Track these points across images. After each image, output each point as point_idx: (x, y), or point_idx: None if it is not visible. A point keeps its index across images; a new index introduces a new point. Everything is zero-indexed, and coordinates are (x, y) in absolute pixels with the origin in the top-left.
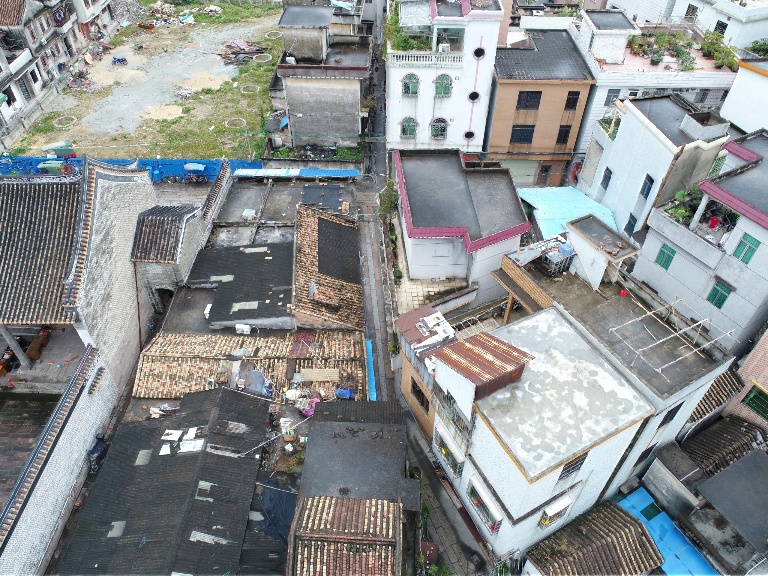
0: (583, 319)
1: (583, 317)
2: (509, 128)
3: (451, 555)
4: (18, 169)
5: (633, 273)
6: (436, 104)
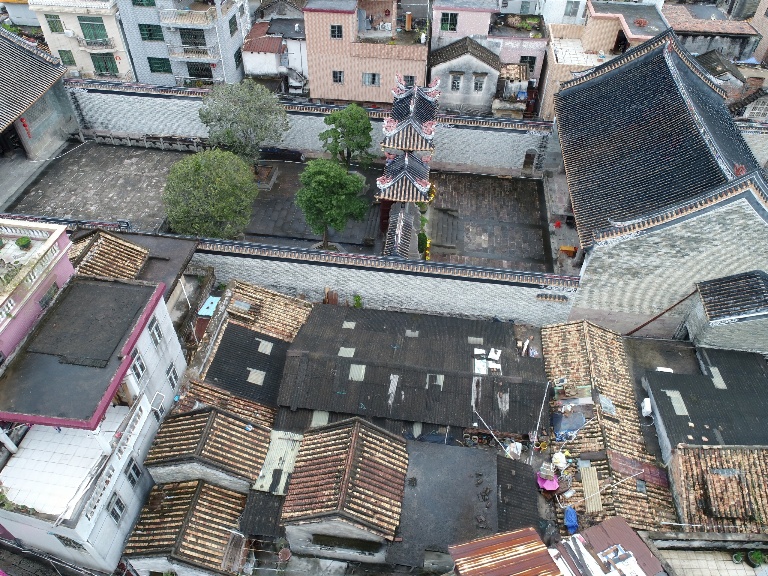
0: None
1: None
2: None
3: None
4: None
5: None
6: None
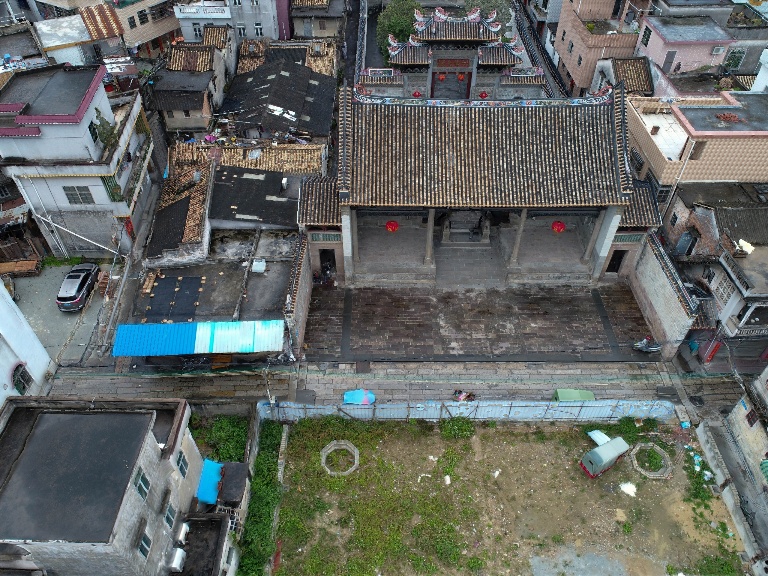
0: (29, 53)
1: (28, 54)
2: None
3: (156, 134)
4: (654, 441)
5: None
6: None
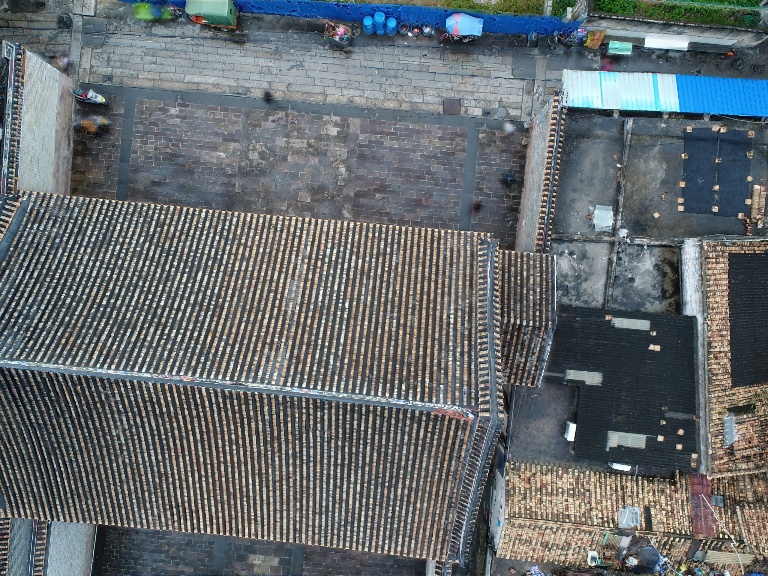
0: None
1: None
2: None
3: None
4: None
5: None
6: None
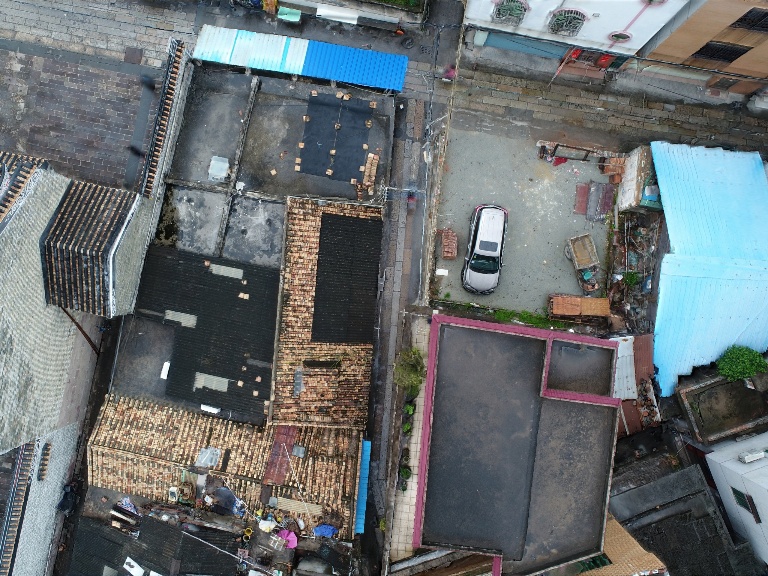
0: None
1: None
2: (701, 41)
3: None
4: None
5: (745, 480)
6: None
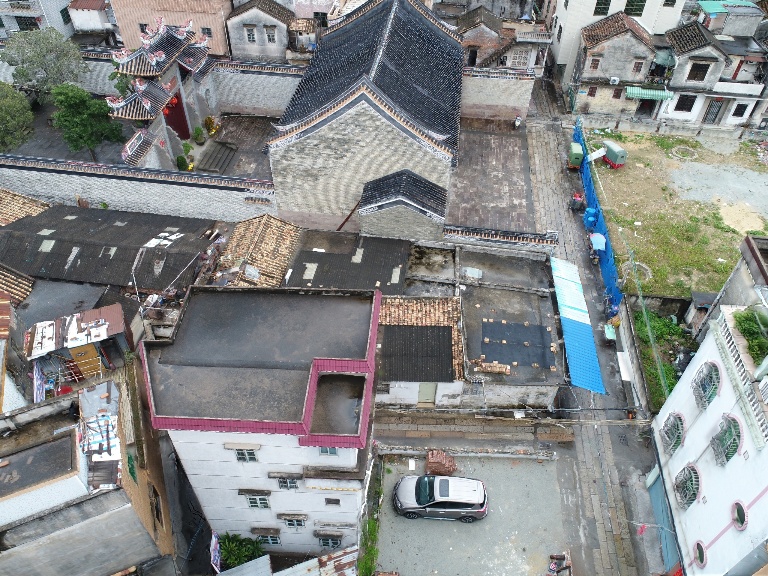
0: None
1: None
2: None
3: None
4: None
5: None
6: (709, 450)
